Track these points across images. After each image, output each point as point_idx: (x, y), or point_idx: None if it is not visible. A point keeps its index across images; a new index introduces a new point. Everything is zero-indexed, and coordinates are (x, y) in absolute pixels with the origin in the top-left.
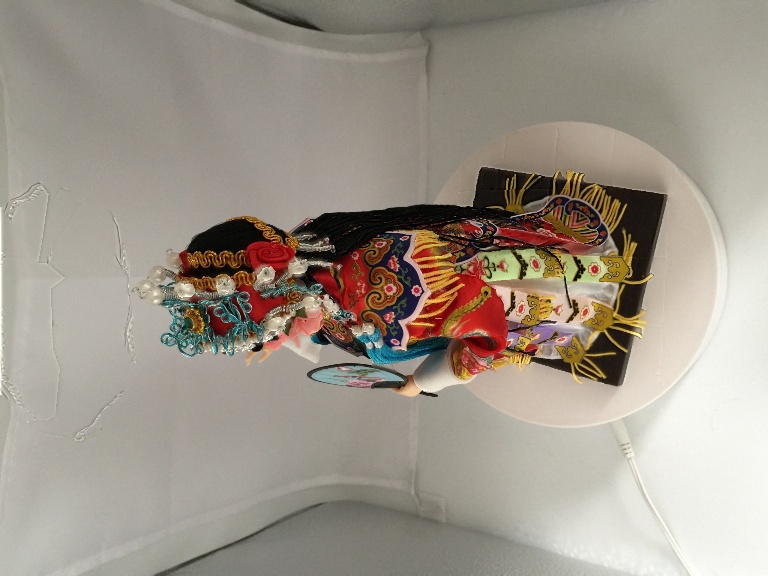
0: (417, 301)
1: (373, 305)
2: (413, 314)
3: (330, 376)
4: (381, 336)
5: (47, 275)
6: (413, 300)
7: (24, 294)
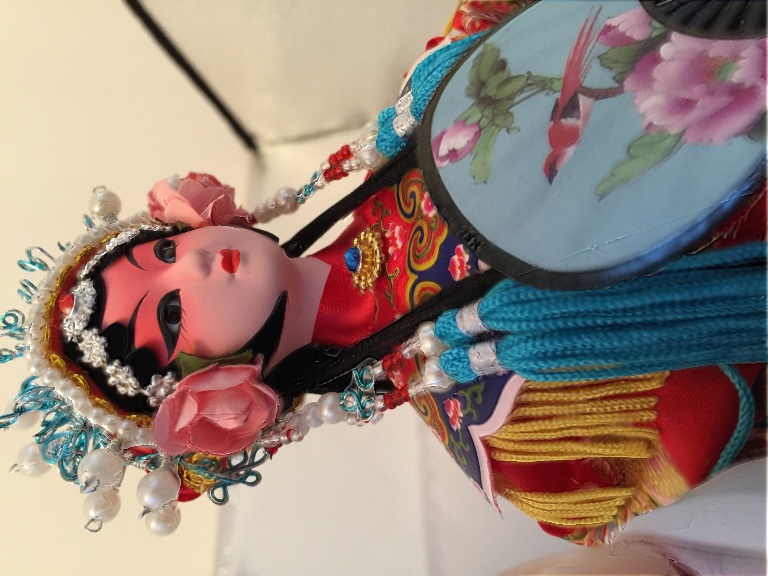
0: None
1: None
2: None
3: (555, 195)
4: None
5: None
6: None
7: None
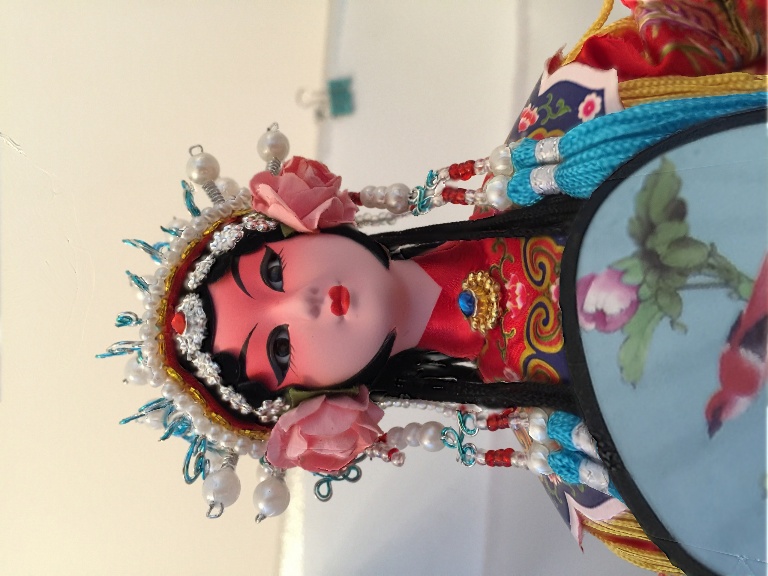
0: None
1: None
2: None
3: (712, 455)
4: None
5: (39, 366)
6: None
7: (4, 390)
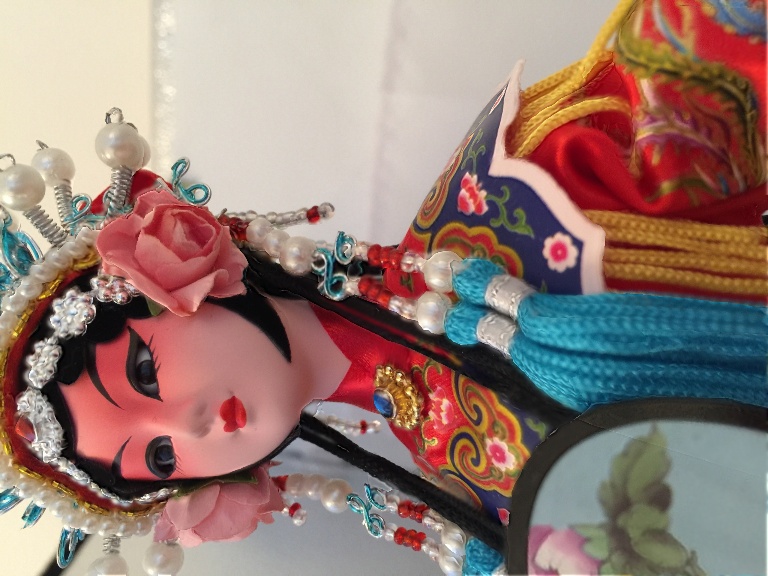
0: (501, 103)
1: (428, 219)
2: (502, 120)
3: None
4: (505, 273)
5: None
6: (494, 113)
7: None
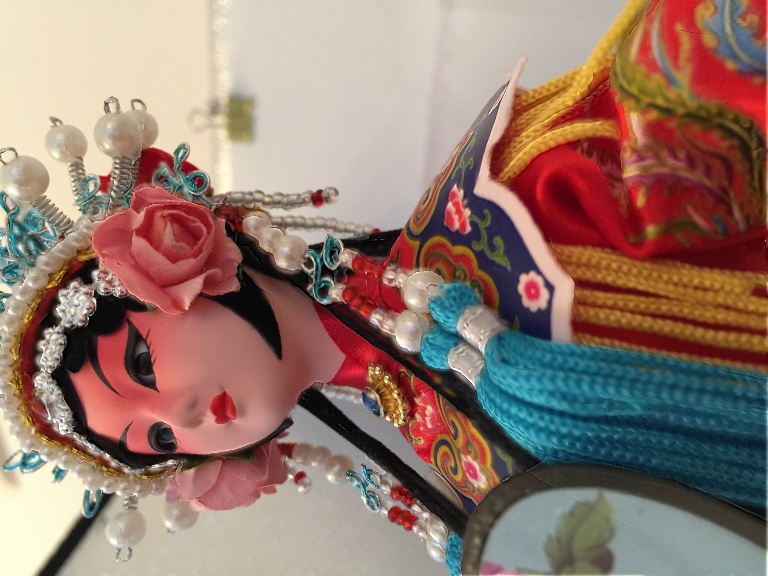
0: (497, 108)
1: (419, 225)
2: (492, 133)
3: None
4: (481, 303)
5: None
6: None
7: None
